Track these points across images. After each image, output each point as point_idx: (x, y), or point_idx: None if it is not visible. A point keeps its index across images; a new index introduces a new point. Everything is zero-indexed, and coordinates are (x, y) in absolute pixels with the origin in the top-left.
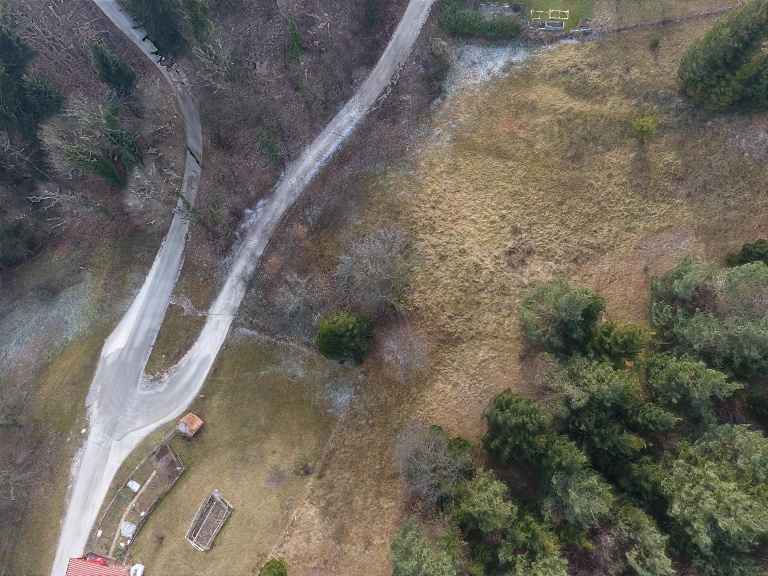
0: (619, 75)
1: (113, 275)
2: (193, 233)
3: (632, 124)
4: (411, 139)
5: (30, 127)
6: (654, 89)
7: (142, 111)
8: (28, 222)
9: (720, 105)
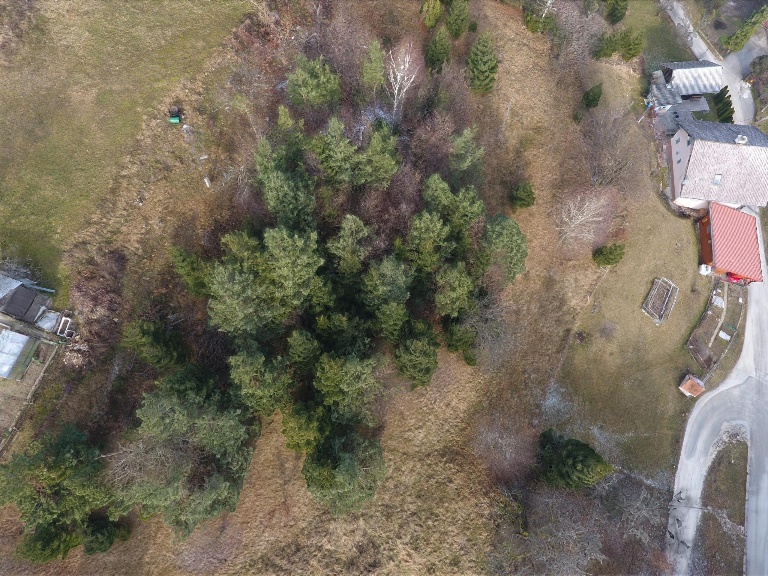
0: None
1: None
2: None
3: None
4: None
5: None
6: None
7: None
8: None
9: None
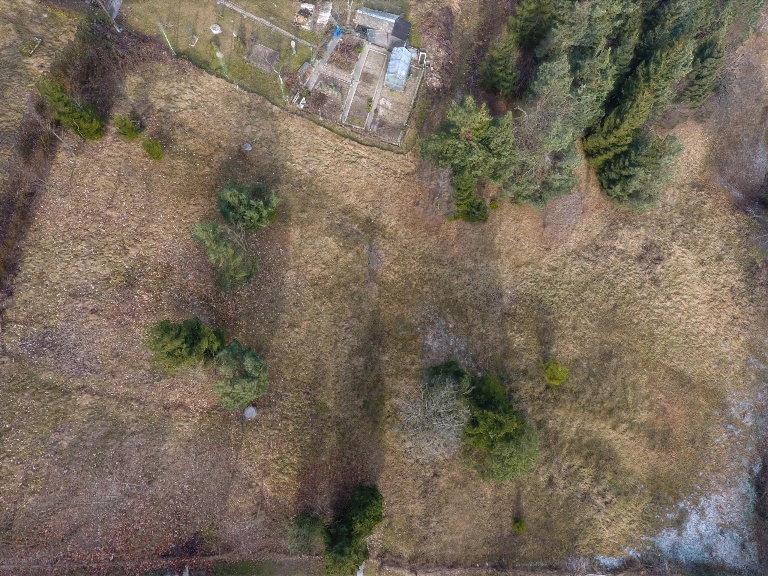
0: None
1: None
2: None
3: None
4: None
5: None
6: None
7: None
8: None
9: None
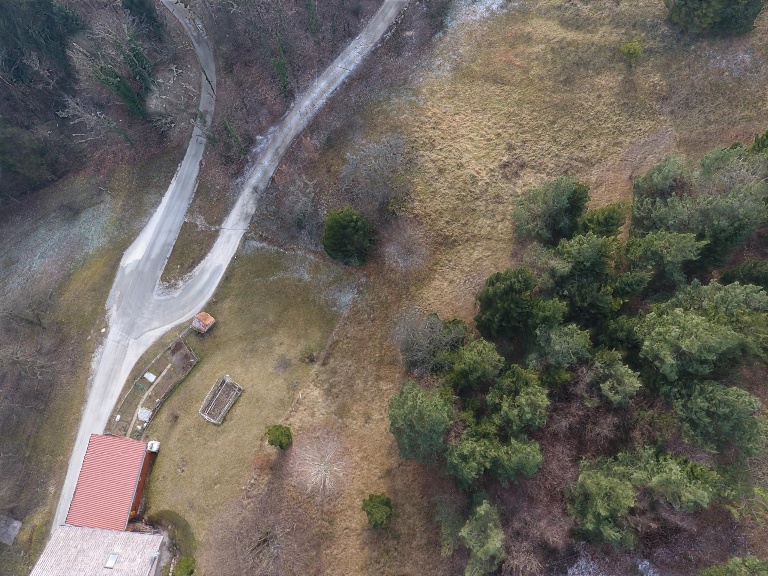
0: (610, 8)
1: (131, 197)
2: (207, 160)
3: (620, 48)
4: (414, 69)
5: (57, 54)
6: (642, 18)
7: (161, 46)
8: (52, 146)
9: (702, 28)
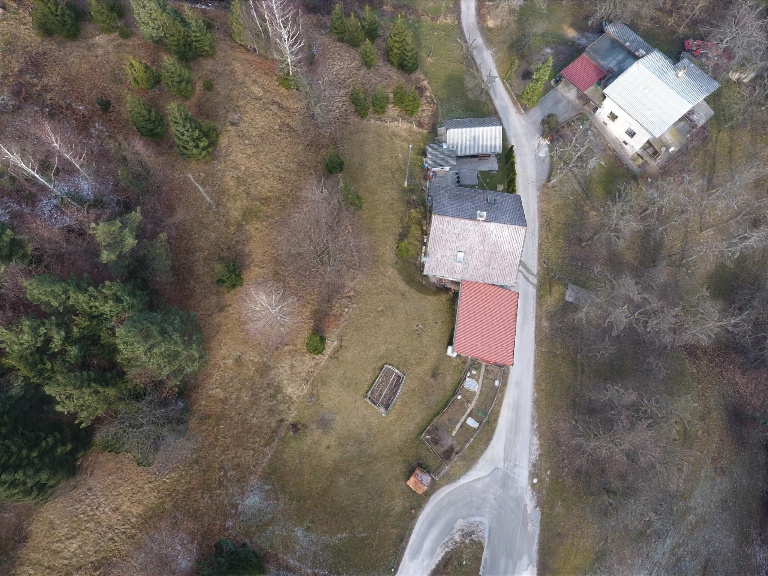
0: None
1: None
2: None
3: None
4: None
5: None
6: None
7: None
8: None
9: None
